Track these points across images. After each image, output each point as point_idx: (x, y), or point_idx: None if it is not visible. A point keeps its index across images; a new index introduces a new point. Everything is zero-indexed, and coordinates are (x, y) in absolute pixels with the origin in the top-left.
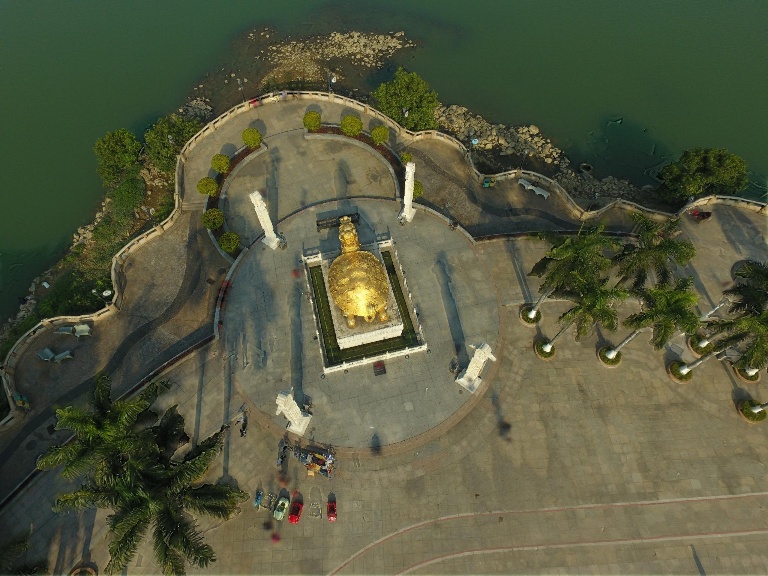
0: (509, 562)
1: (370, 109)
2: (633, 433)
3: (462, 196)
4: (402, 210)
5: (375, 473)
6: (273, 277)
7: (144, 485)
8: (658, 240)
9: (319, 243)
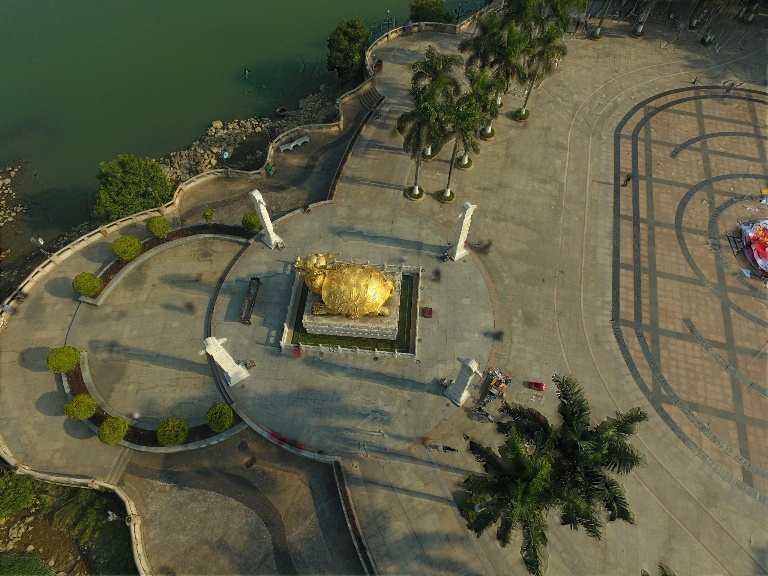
0: (590, 278)
1: (107, 228)
2: (521, 176)
3: (271, 195)
4: (266, 242)
5: (513, 345)
6: (286, 384)
7: (593, 437)
8: (441, 65)
9: (265, 327)
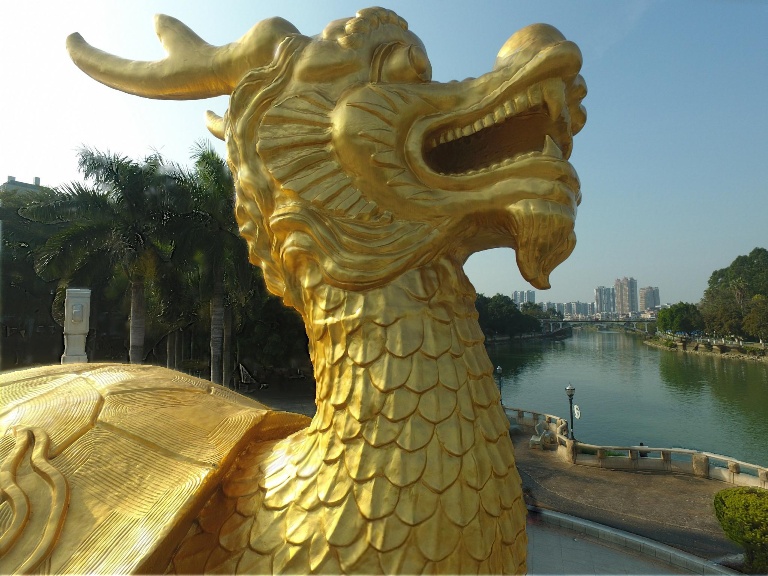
0: None
1: None
2: None
3: None
4: None
5: None
6: None
7: None
8: None
9: None
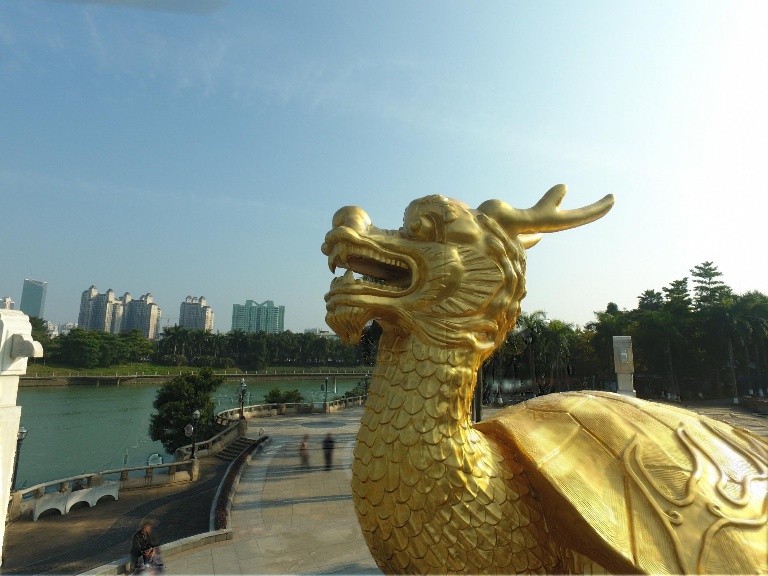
0: None
1: None
2: None
3: None
4: None
5: None
6: None
7: None
8: None
9: None
